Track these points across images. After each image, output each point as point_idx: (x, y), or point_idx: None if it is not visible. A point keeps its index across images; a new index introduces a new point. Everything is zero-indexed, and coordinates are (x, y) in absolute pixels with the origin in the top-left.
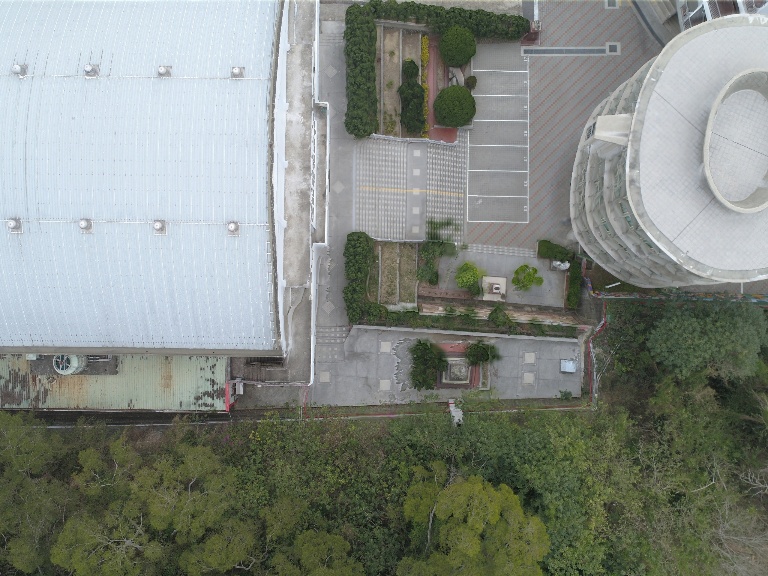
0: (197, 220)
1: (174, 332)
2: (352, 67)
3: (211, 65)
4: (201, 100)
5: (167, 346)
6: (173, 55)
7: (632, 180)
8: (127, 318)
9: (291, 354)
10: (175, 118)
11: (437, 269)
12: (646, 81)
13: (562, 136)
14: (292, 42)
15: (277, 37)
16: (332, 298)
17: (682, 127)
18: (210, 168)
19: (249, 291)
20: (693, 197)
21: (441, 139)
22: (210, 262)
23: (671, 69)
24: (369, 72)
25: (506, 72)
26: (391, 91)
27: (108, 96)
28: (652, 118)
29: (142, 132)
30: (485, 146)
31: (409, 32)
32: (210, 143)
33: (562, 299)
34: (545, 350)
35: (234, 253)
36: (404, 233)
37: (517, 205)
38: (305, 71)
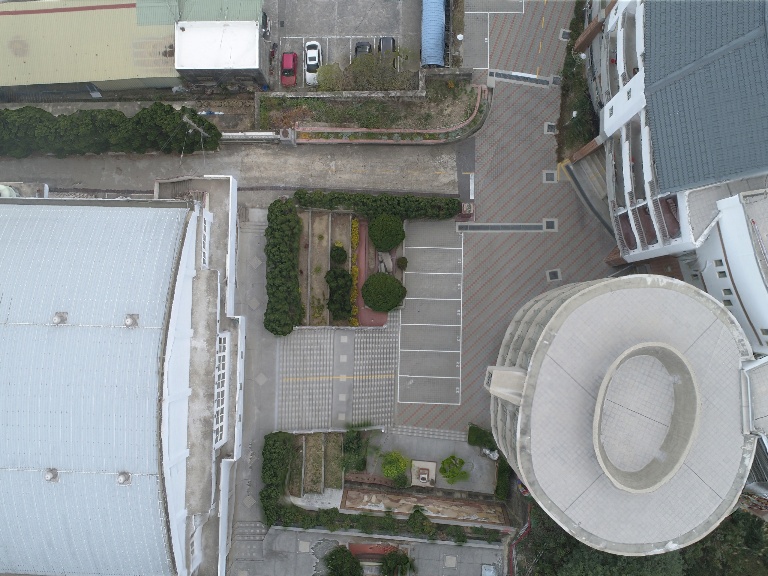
0: (88, 469)
1: (74, 564)
2: (272, 266)
3: (106, 312)
4: (94, 350)
5: (68, 575)
6: (70, 300)
7: (523, 446)
8: (26, 552)
9: (200, 568)
10: (68, 369)
11: (365, 454)
12: (539, 344)
13: (496, 315)
14: (199, 266)
15: (173, 281)
16: (253, 492)
17: (575, 393)
18: (101, 420)
19: (143, 533)
20: (586, 466)
21: (372, 319)
22: (103, 508)
23: (564, 332)
24: (290, 271)
25: (440, 249)
26: (319, 275)
27: (4, 344)
28: (544, 383)
29: (35, 383)
30: (417, 325)
31: (339, 214)
32: (101, 395)
33: (493, 485)
34: (466, 554)
35: (126, 500)
36: (330, 421)
37: (449, 386)
38: (210, 297)
